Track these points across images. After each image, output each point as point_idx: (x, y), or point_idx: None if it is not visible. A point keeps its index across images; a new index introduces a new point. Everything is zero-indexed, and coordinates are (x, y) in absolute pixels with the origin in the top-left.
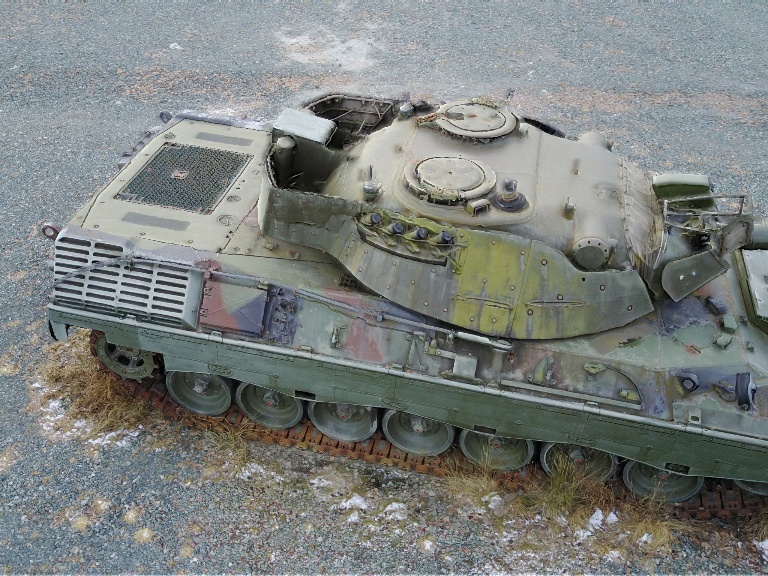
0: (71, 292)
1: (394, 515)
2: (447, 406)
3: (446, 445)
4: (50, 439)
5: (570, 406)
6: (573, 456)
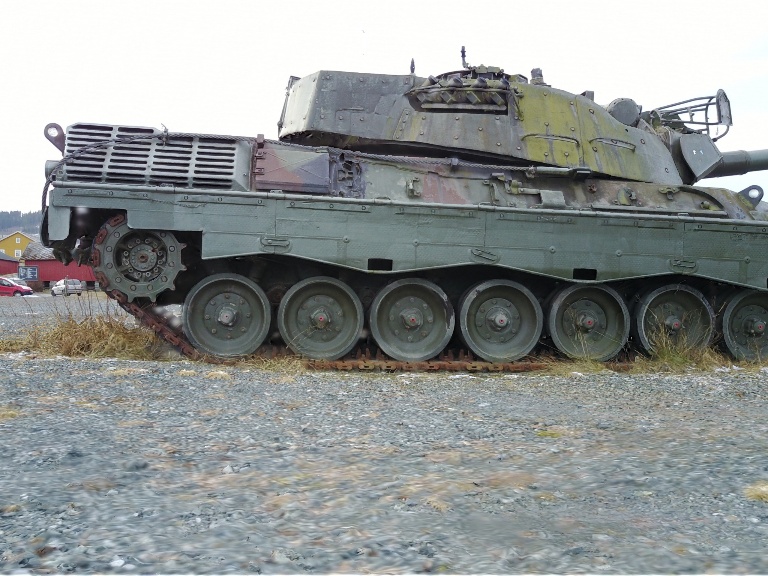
0: (88, 166)
1: None
2: (543, 246)
3: (535, 336)
4: None
5: (665, 217)
6: (669, 321)
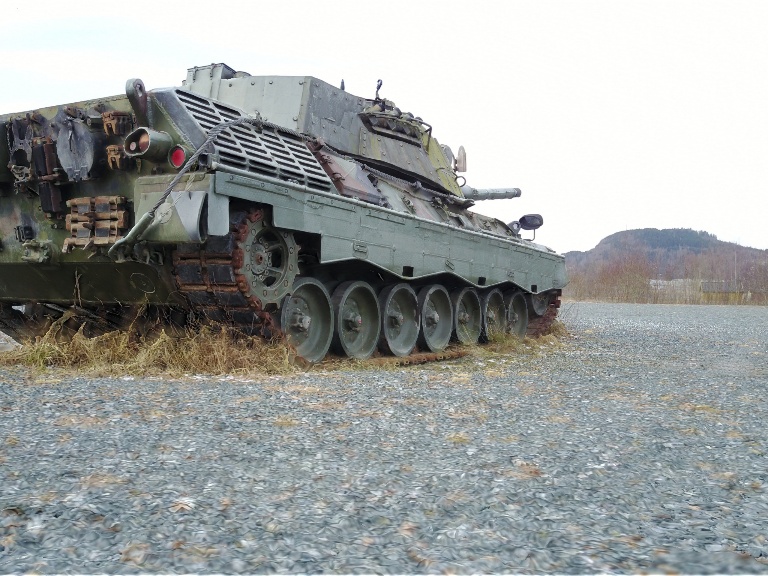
0: (230, 148)
1: None
2: (469, 259)
3: (451, 329)
4: None
5: None
6: None
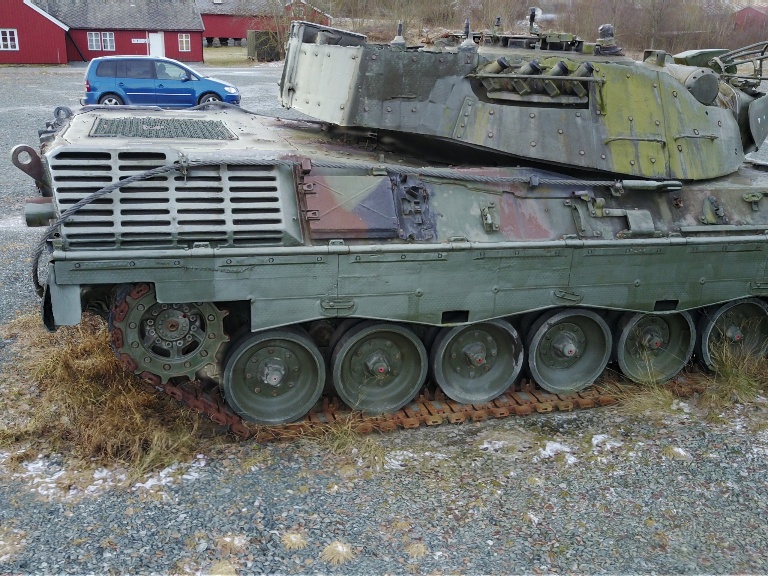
0: (93, 225)
1: (610, 444)
2: (628, 280)
3: (603, 363)
4: (65, 501)
5: (754, 238)
6: (731, 334)
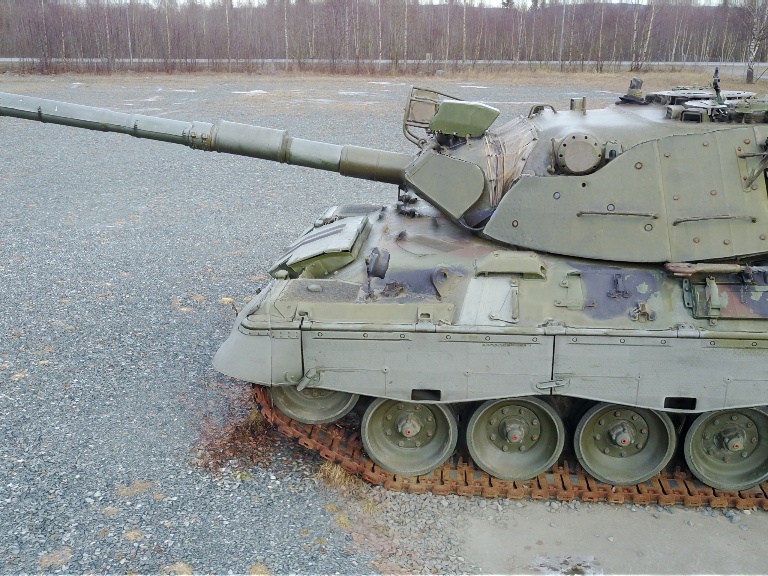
0: None
1: None
2: None
3: None
4: None
5: None
6: None
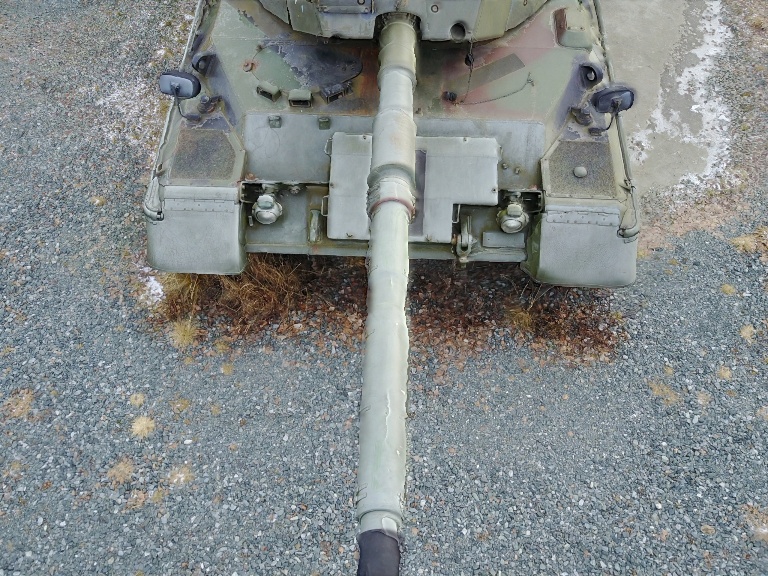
0: None
1: None
2: None
3: None
4: None
5: None
6: None
